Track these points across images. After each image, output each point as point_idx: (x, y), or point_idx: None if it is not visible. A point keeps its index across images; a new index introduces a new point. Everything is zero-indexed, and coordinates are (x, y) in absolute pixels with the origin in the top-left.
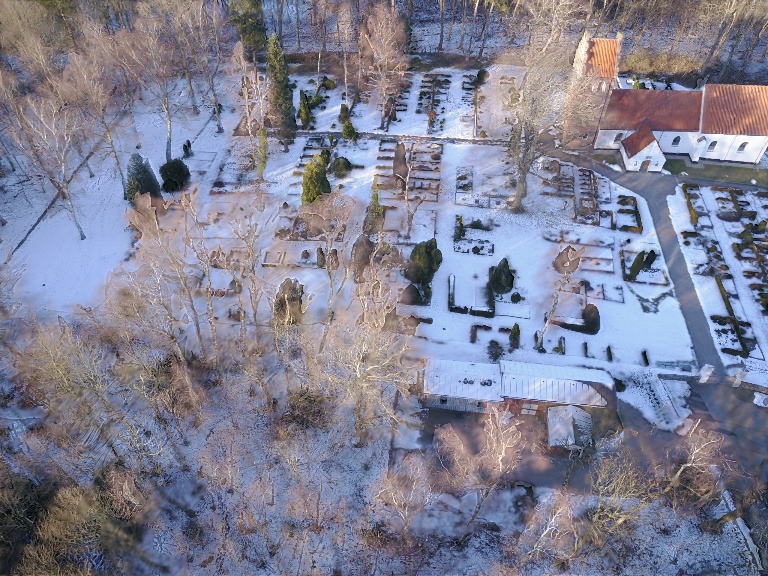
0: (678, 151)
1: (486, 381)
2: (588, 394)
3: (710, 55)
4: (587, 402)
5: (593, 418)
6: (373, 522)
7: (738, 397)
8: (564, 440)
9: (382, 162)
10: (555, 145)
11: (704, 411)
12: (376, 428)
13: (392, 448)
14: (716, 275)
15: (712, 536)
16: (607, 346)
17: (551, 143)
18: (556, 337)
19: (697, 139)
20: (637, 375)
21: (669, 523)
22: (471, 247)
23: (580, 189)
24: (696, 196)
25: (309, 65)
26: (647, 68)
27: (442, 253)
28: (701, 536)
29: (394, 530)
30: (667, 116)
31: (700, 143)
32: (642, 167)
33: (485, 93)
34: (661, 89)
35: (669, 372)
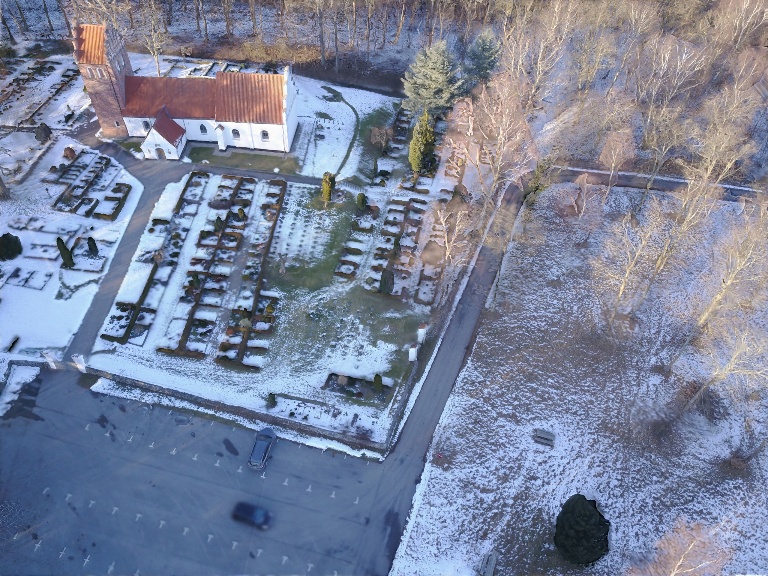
0: (210, 139)
1: None
2: None
3: (321, 44)
4: None
5: None
6: None
7: (78, 383)
8: None
9: None
10: (96, 133)
11: (31, 397)
12: None
13: None
14: (155, 262)
15: None
16: None
17: (95, 131)
18: None
19: None
20: None
21: None
22: None
23: (83, 177)
24: (195, 184)
25: None
26: (265, 57)
27: None
28: None
29: None
30: (185, 104)
31: (216, 131)
32: (161, 155)
33: (80, 80)
34: None
35: (22, 358)
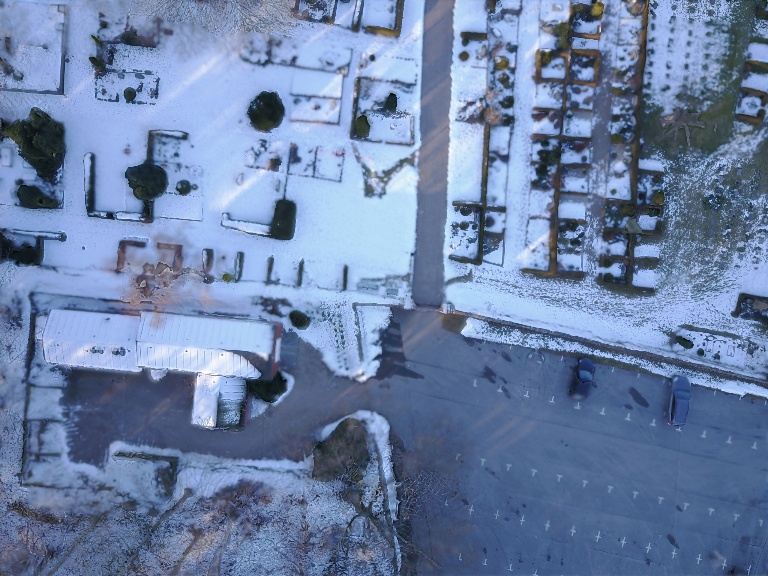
0: None
1: (118, 350)
2: (239, 366)
3: None
4: (238, 374)
5: (248, 385)
6: (12, 500)
7: (445, 327)
8: (206, 420)
9: None
10: None
11: (397, 349)
12: (5, 396)
13: (26, 420)
14: (486, 123)
15: (349, 504)
16: (300, 259)
17: None
18: (234, 250)
19: None
20: (327, 305)
21: (309, 493)
22: (122, 88)
23: None
24: None
25: None
26: None
27: (76, 105)
28: (338, 504)
29: (33, 508)
30: None
31: None
32: None
33: None
34: None
35: (367, 300)
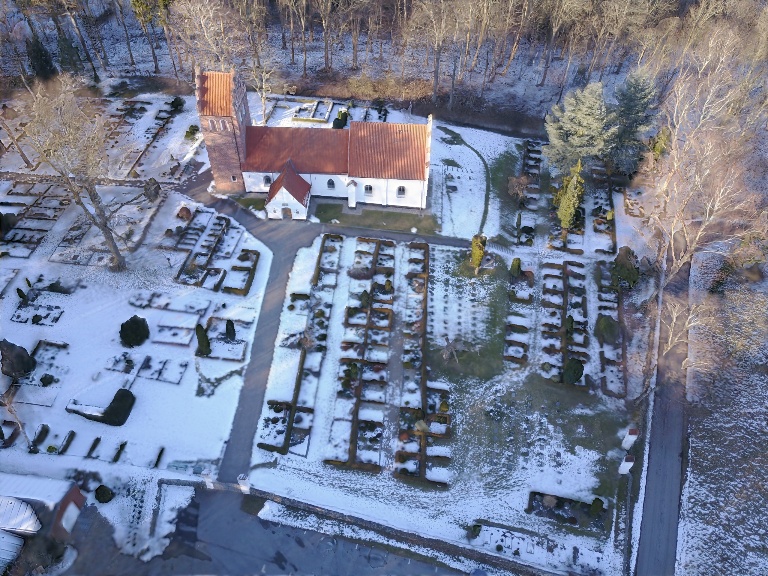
0: (337, 195)
1: None
2: (23, 515)
3: (435, 80)
4: (18, 526)
5: (25, 545)
6: None
7: (243, 508)
8: None
9: (1, 208)
10: (208, 187)
11: (191, 527)
12: None
13: None
14: (302, 348)
15: None
16: (124, 441)
17: (206, 185)
18: (68, 430)
19: (347, 183)
20: (135, 480)
21: None
22: (34, 315)
23: (204, 241)
24: (330, 249)
25: (4, 90)
26: (372, 94)
27: None
28: None
29: None
30: (313, 157)
31: (349, 187)
32: (286, 214)
33: (176, 124)
34: (373, 118)
35: (173, 476)
